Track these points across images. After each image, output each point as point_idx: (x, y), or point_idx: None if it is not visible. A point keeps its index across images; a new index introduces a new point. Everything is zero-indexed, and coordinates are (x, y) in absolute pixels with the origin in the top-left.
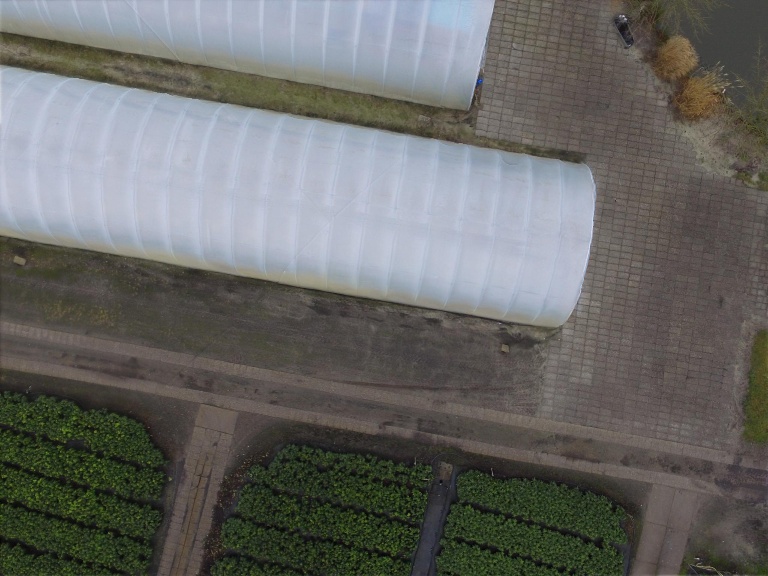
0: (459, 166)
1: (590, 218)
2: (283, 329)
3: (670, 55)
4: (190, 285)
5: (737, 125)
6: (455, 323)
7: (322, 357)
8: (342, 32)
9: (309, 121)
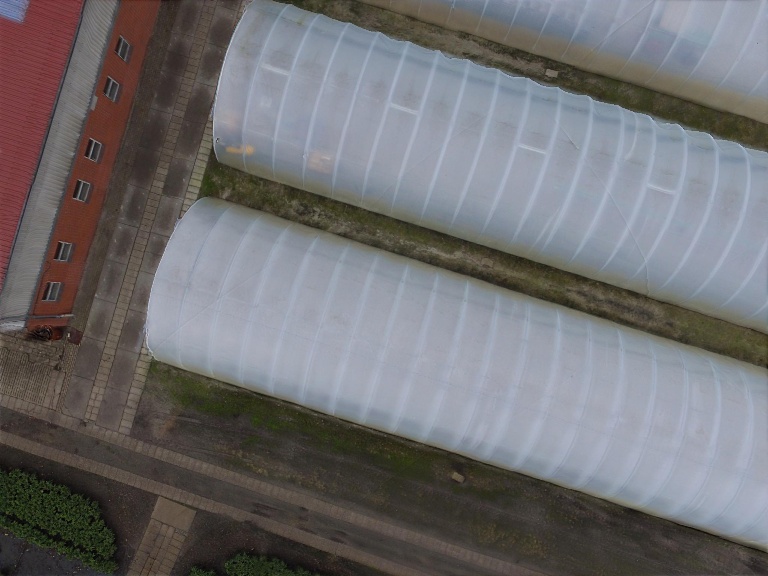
0: None
1: None
2: None
3: None
4: (628, 526)
5: None
6: None
7: None
8: None
9: None
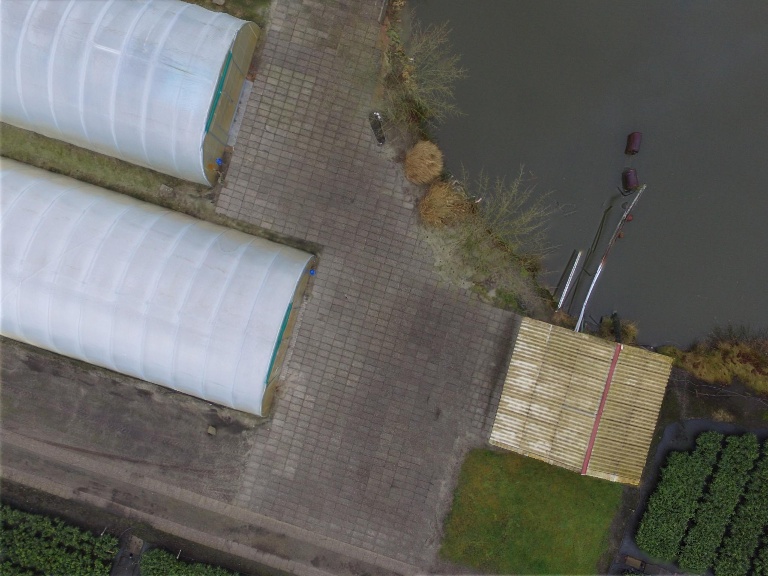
0: (162, 247)
1: (279, 319)
2: None
3: (407, 161)
4: None
5: (483, 237)
6: (166, 398)
7: (27, 413)
8: (67, 97)
9: (33, 179)
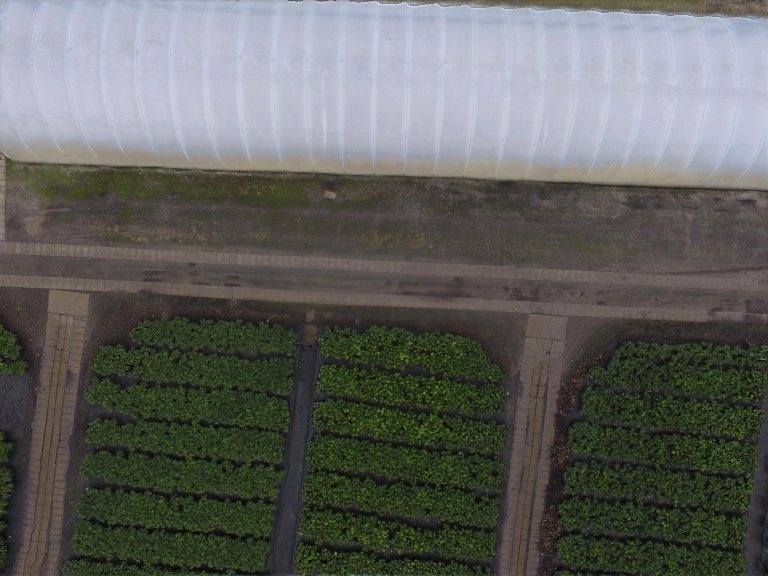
0: None
1: None
2: (600, 229)
3: None
4: (501, 198)
5: None
6: None
7: (643, 252)
8: None
9: (616, 12)
